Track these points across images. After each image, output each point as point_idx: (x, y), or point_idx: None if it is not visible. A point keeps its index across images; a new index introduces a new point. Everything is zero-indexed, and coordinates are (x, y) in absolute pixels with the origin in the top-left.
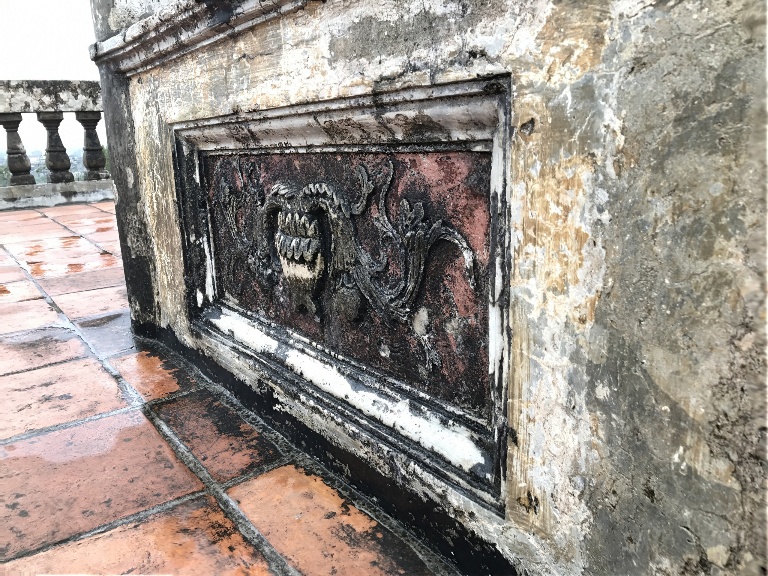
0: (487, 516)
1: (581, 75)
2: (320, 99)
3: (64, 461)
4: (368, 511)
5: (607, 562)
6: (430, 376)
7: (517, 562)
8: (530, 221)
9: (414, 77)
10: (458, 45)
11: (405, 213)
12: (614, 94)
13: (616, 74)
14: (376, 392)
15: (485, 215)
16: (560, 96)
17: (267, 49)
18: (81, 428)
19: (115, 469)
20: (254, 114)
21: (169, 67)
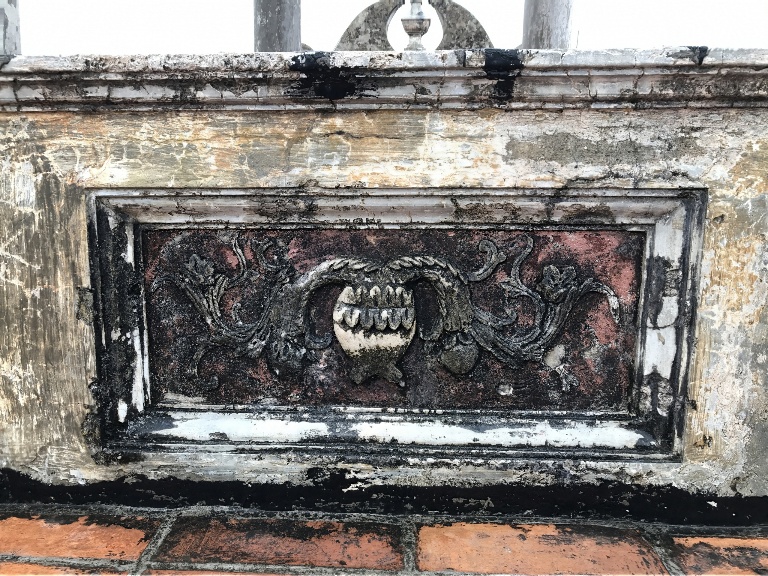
0: (666, 467)
1: (758, 195)
2: (485, 186)
3: None
4: (535, 522)
5: (760, 452)
6: (563, 396)
7: (690, 486)
8: (717, 272)
9: (617, 181)
10: (663, 167)
11: (553, 275)
12: None
13: None
14: (506, 426)
15: (631, 272)
16: (744, 204)
17: (393, 133)
18: None
19: None
20: (342, 190)
21: (107, 118)
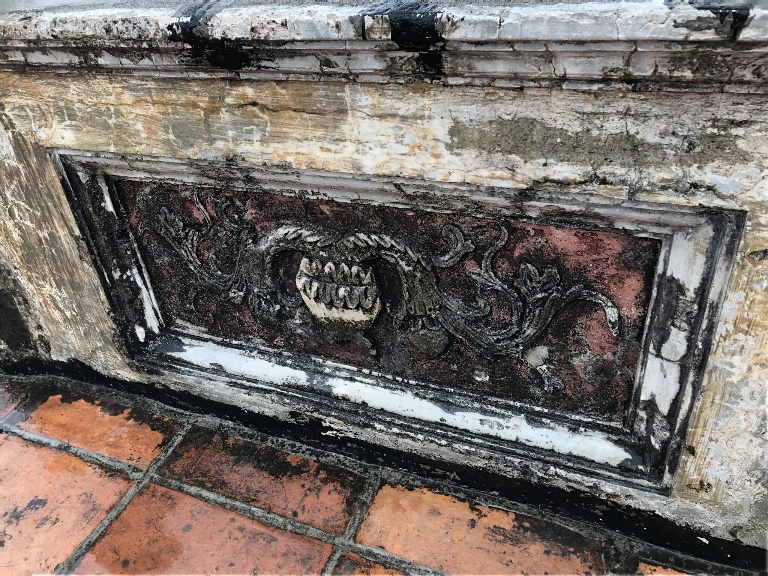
0: (649, 497)
1: None
2: (427, 179)
3: None
4: (497, 505)
5: None
6: (546, 394)
7: (678, 519)
8: (745, 319)
9: (603, 189)
10: (677, 175)
11: (530, 276)
12: None
13: None
14: (478, 411)
15: (639, 283)
16: None
17: (311, 108)
18: (112, 537)
19: (220, 570)
20: (271, 167)
21: (38, 78)
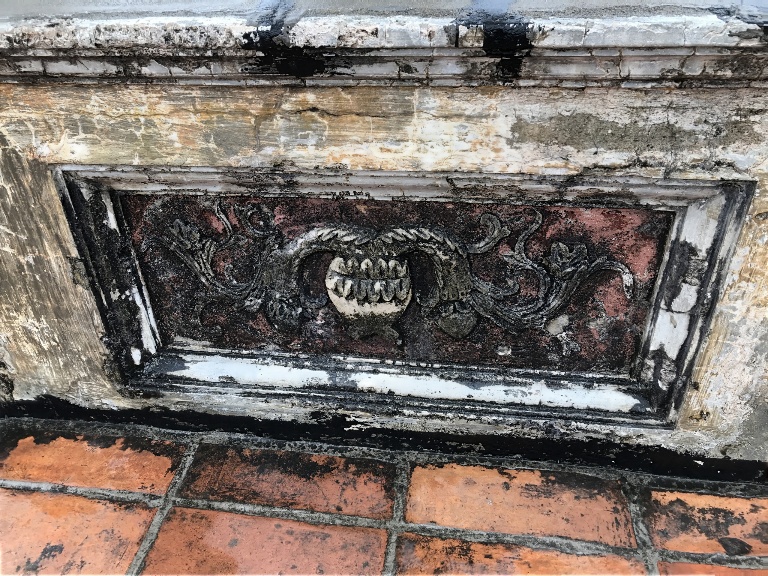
0: (658, 433)
1: None
2: (485, 172)
3: None
4: (522, 467)
5: (758, 427)
6: (563, 359)
7: (679, 448)
8: (748, 269)
9: (644, 171)
10: (705, 155)
11: (561, 253)
12: None
13: None
14: (501, 383)
15: (652, 250)
16: None
17: (376, 111)
18: (154, 567)
19: (284, 574)
20: (322, 170)
21: (51, 90)
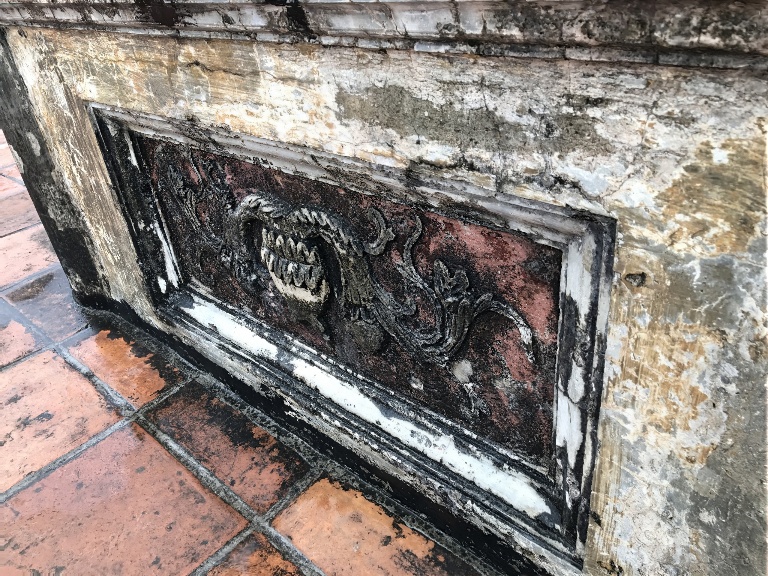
0: (562, 564)
1: (717, 255)
2: (326, 151)
3: (85, 512)
4: (421, 530)
5: None
6: (475, 417)
7: None
8: (632, 362)
9: (472, 176)
10: (539, 165)
11: (443, 276)
12: (760, 287)
13: (765, 269)
14: (412, 421)
15: (548, 302)
16: (685, 265)
17: (234, 68)
18: (82, 460)
19: (145, 515)
20: (219, 129)
21: (70, 34)
